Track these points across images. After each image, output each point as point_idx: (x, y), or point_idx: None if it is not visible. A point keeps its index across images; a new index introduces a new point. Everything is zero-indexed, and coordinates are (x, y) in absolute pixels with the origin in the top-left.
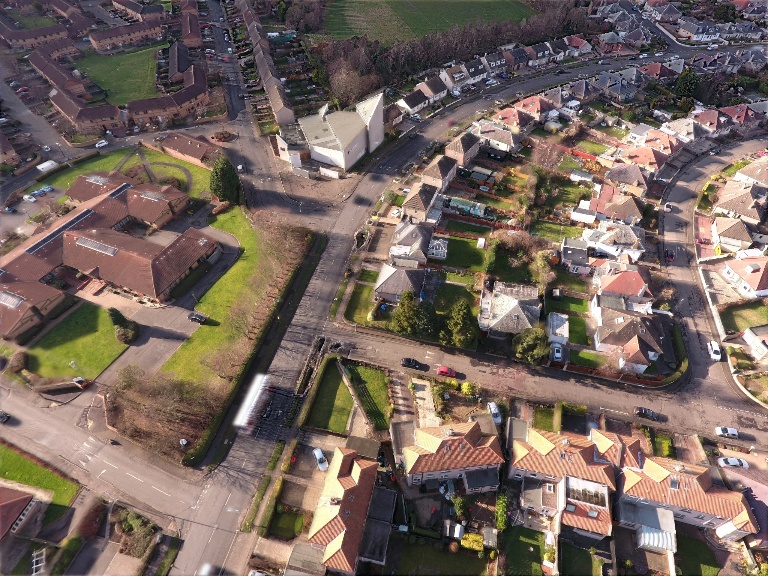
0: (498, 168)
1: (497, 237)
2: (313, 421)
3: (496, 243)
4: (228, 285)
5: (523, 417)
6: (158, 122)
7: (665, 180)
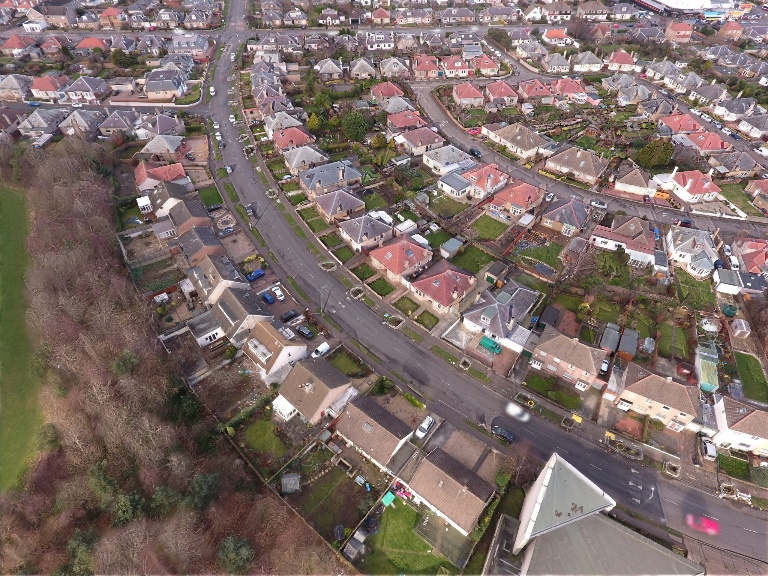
0: None
1: None
2: None
3: None
4: None
5: None
6: None
7: (552, 194)
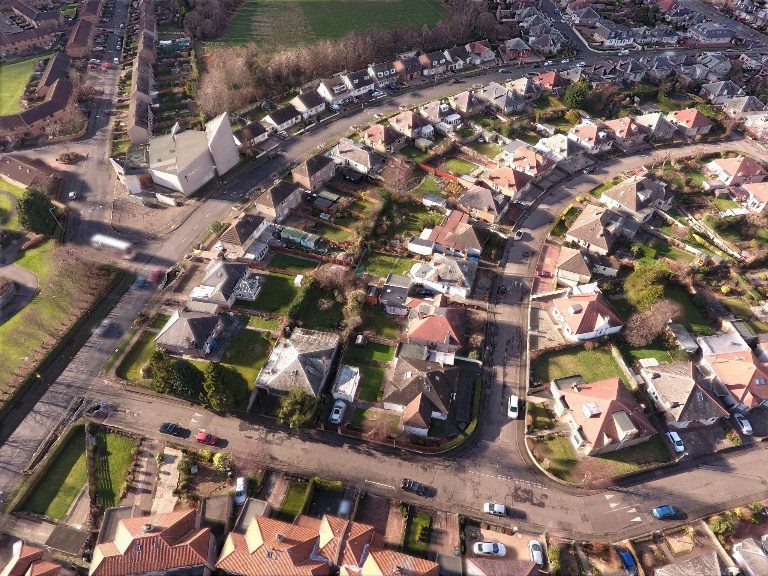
0: (349, 192)
1: (313, 275)
2: (31, 505)
3: (309, 282)
4: (5, 335)
5: (274, 494)
6: (7, 142)
7: (524, 203)
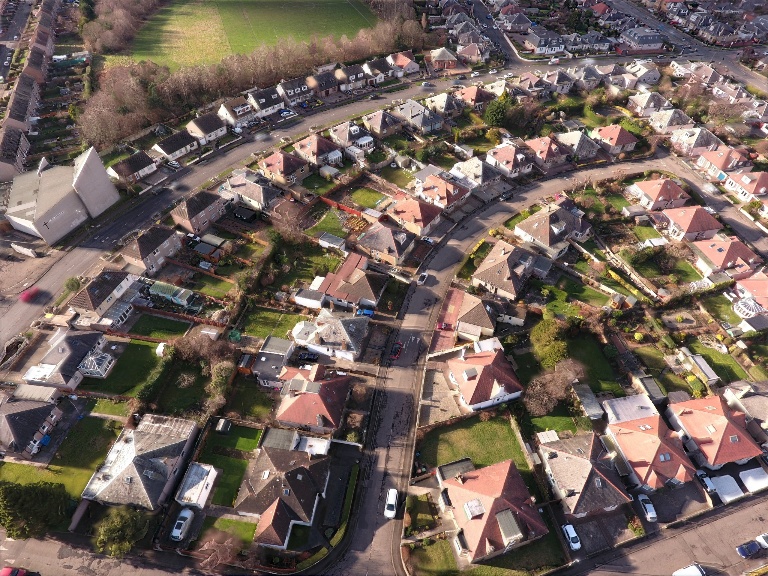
0: (239, 233)
1: (176, 343)
2: None
3: (170, 353)
4: None
5: None
6: None
7: (431, 240)
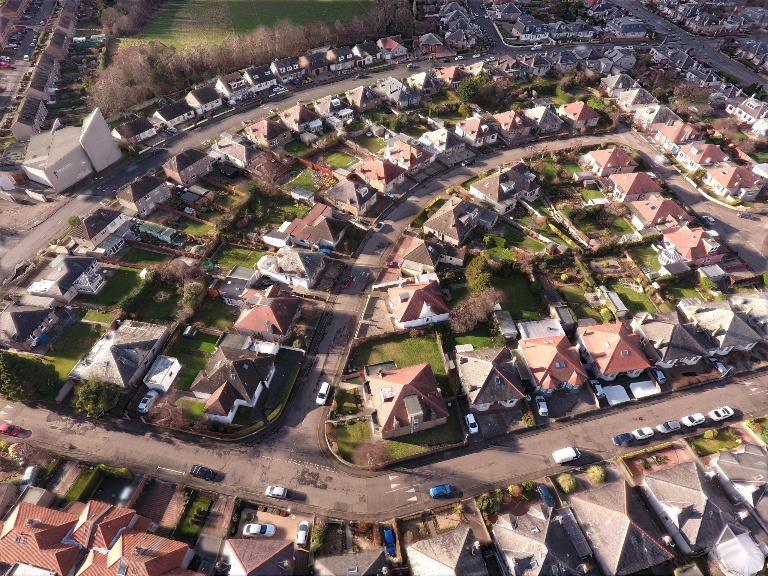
0: (222, 186)
1: (156, 268)
2: None
3: (150, 275)
4: None
5: (63, 482)
6: None
7: (392, 196)
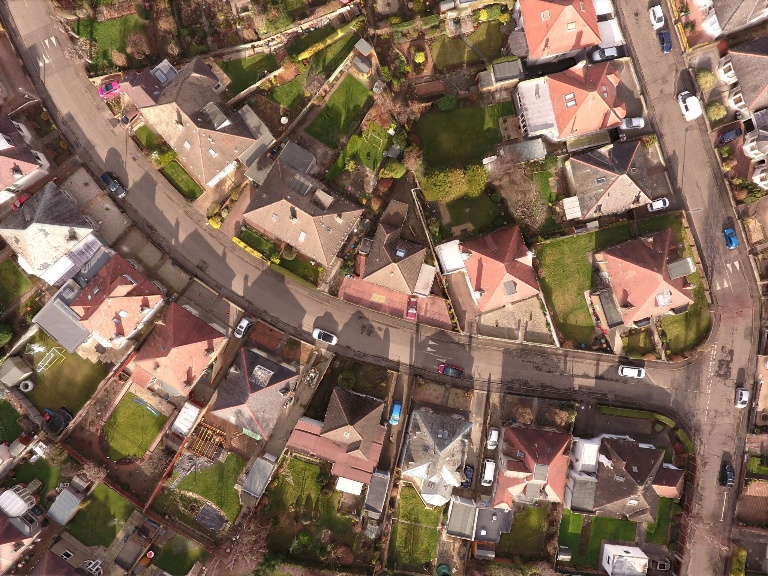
0: None
1: None
2: None
3: None
4: None
5: None
6: None
7: (245, 322)
